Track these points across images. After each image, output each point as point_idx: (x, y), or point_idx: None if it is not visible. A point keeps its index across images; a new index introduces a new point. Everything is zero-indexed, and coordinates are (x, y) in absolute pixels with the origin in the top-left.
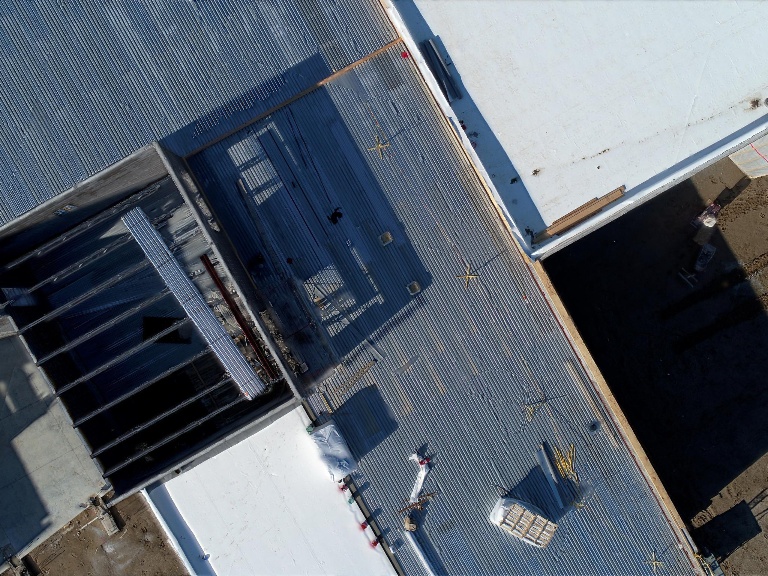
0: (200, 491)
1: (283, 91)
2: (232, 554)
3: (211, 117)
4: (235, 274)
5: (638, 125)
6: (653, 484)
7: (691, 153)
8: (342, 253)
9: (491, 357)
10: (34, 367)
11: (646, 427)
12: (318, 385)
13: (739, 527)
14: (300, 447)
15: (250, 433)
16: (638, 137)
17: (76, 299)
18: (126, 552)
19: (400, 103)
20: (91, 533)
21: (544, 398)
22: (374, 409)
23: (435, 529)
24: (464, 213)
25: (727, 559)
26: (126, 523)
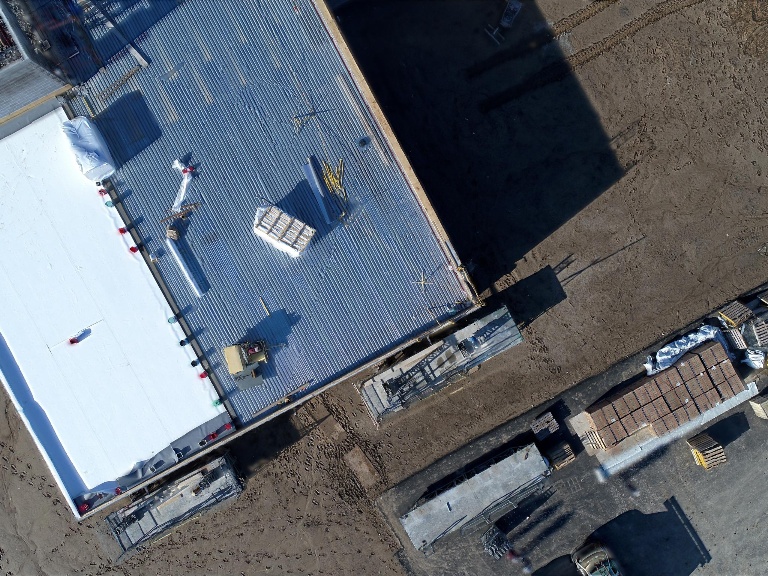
0: None
1: None
2: None
3: None
4: None
5: None
6: (417, 195)
7: None
8: None
9: (259, 67)
10: None
11: (450, 187)
12: (80, 88)
13: (544, 292)
14: (59, 150)
15: (7, 133)
16: None
17: None
18: None
19: None
20: None
21: (312, 111)
22: (137, 115)
23: (198, 240)
24: None
25: (531, 324)
26: None
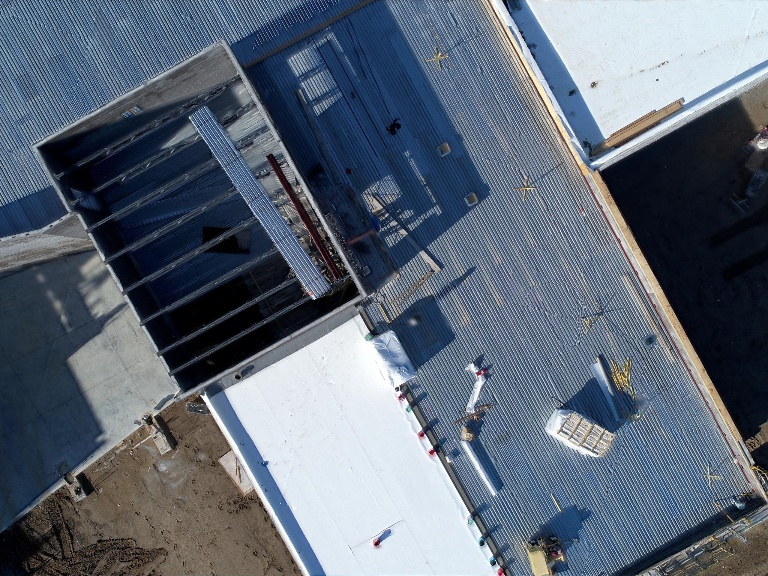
0: (259, 398)
1: (342, 3)
2: (290, 461)
3: (271, 28)
4: (300, 174)
5: (698, 37)
6: (710, 396)
7: (751, 66)
8: (400, 164)
9: (548, 269)
10: (89, 287)
11: None
12: (376, 295)
13: None
14: (358, 356)
15: (309, 341)
16: (697, 49)
17: (144, 198)
18: (178, 471)
19: (459, 15)
20: (144, 452)
21: (600, 311)
22: (431, 320)
23: (491, 440)
24: (522, 125)
25: None
26: (178, 443)
